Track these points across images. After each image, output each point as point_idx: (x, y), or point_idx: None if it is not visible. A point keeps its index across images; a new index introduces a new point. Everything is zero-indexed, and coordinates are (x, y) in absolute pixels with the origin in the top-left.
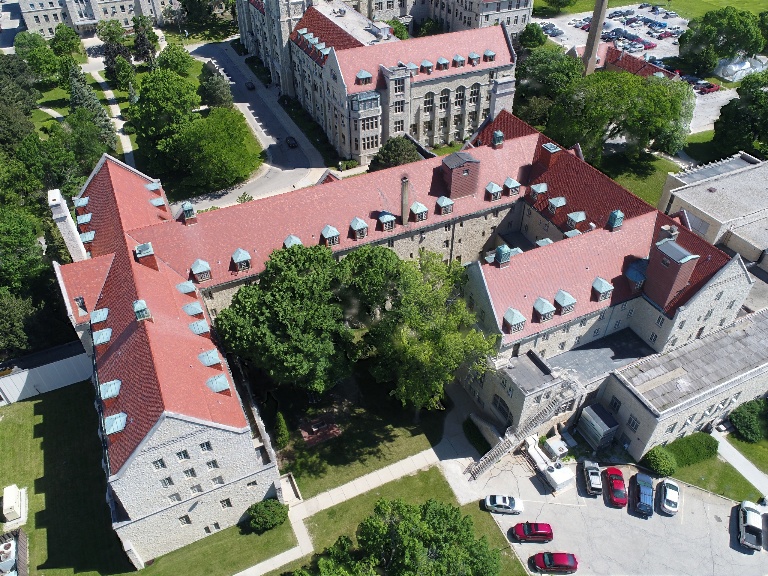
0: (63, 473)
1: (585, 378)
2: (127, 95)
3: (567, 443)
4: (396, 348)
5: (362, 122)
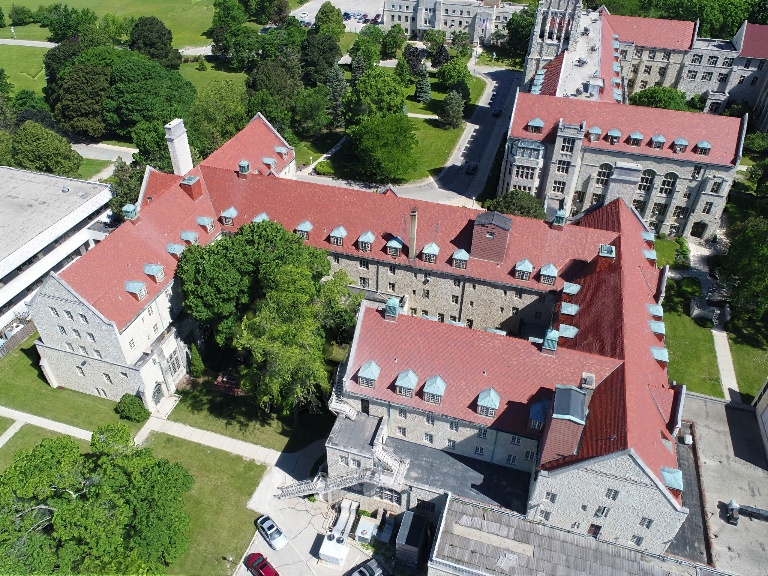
0: None
1: (422, 481)
2: None
3: (380, 534)
4: None
5: (517, 168)
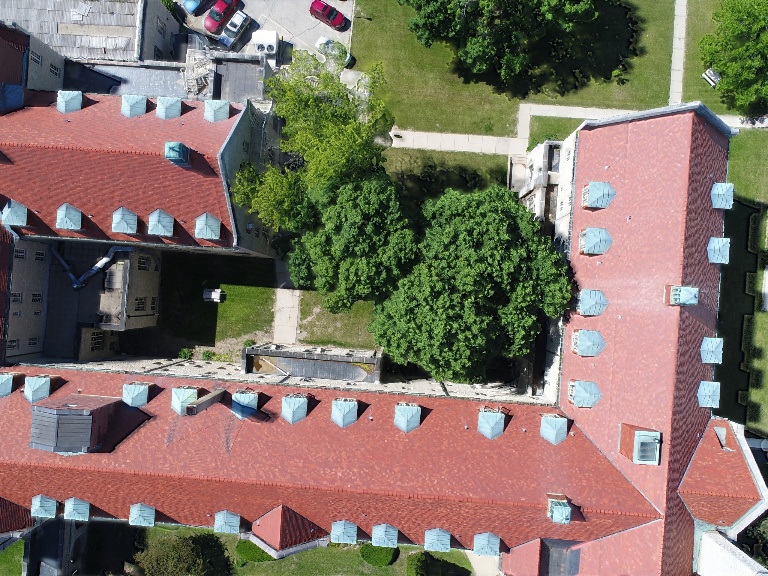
0: (725, 309)
1: (171, 76)
2: None
3: None
4: (372, 164)
5: None
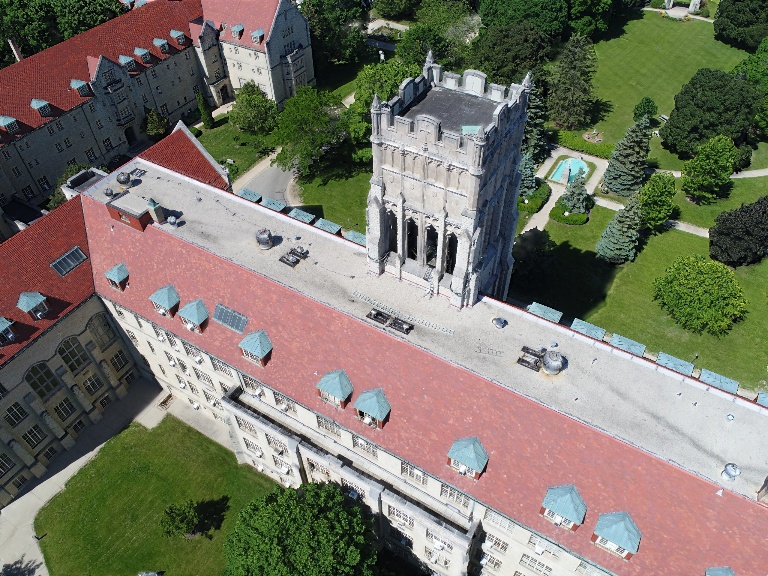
0: None
1: None
2: (667, 237)
3: None
4: None
5: None
